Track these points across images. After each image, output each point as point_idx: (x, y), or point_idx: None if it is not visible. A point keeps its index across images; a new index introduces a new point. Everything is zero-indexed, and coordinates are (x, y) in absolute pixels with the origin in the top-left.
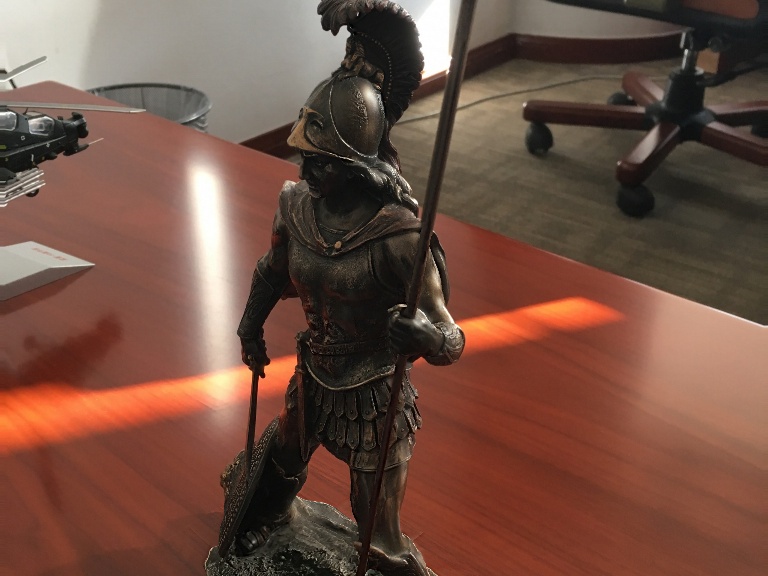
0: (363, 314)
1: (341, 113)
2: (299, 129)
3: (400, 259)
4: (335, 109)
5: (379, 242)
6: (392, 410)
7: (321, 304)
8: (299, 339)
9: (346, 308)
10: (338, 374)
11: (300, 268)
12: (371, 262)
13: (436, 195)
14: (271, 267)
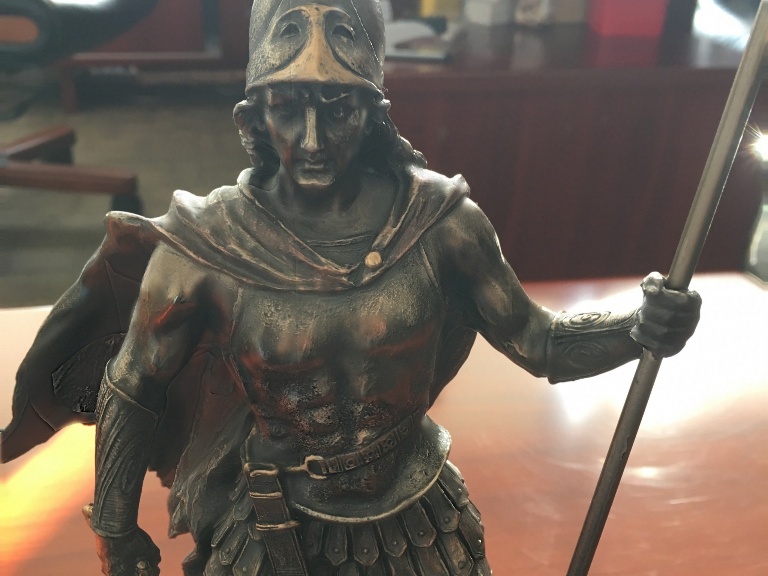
0: (420, 363)
1: (364, 7)
2: (321, 46)
3: (477, 242)
4: (355, 1)
5: (432, 229)
6: (619, 464)
7: (344, 380)
8: (276, 470)
9: (398, 364)
10: (384, 486)
11: (294, 333)
12: (431, 266)
13: (767, 48)
14: (153, 376)
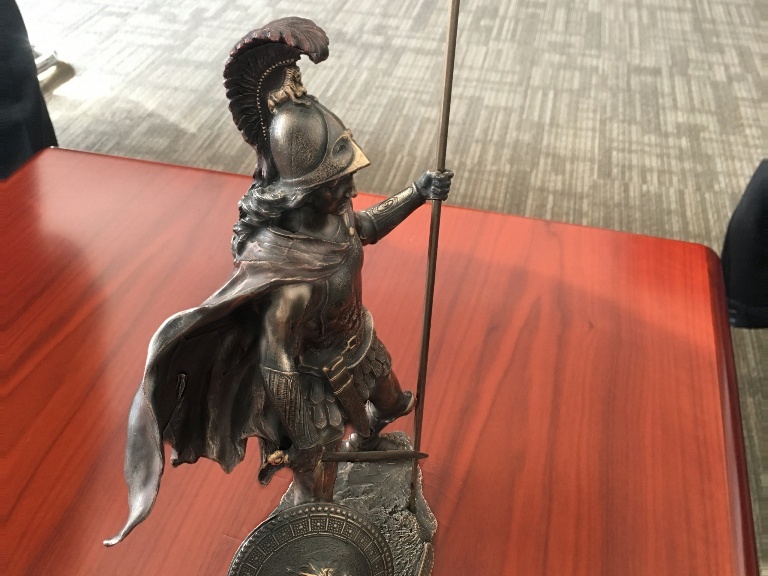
0: None
1: None
2: None
3: None
4: None
5: None
6: None
7: (356, 293)
8: None
9: None
10: None
11: (349, 284)
12: None
13: None
14: None
